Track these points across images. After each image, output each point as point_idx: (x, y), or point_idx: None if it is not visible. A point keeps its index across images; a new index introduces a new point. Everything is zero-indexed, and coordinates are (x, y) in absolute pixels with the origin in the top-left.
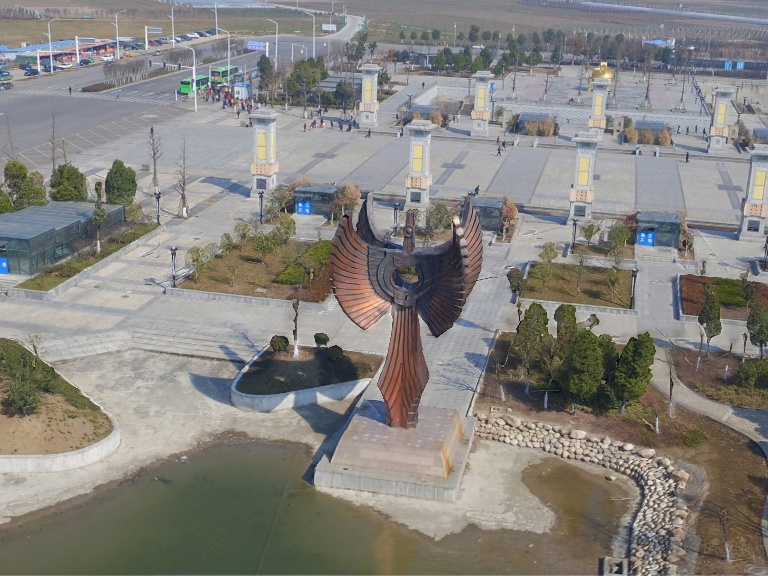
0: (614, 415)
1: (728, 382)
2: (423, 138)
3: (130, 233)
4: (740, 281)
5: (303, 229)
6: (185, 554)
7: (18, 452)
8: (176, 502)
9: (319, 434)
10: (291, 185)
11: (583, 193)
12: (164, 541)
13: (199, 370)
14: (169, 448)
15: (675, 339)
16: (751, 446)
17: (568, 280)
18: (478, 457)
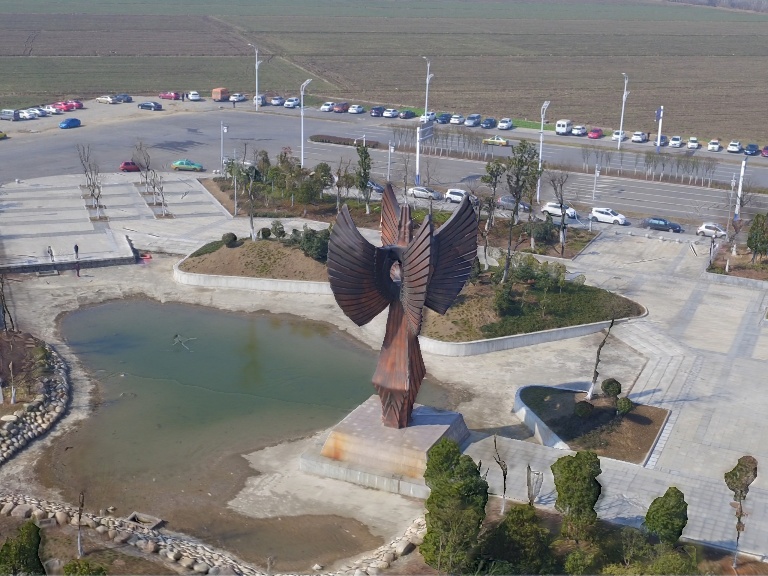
0: None
1: None
2: None
3: None
4: None
5: None
6: (278, 375)
7: None
8: (354, 375)
9: None
10: None
11: None
12: (299, 370)
13: None
14: (441, 373)
15: None
16: None
17: None
18: (391, 498)
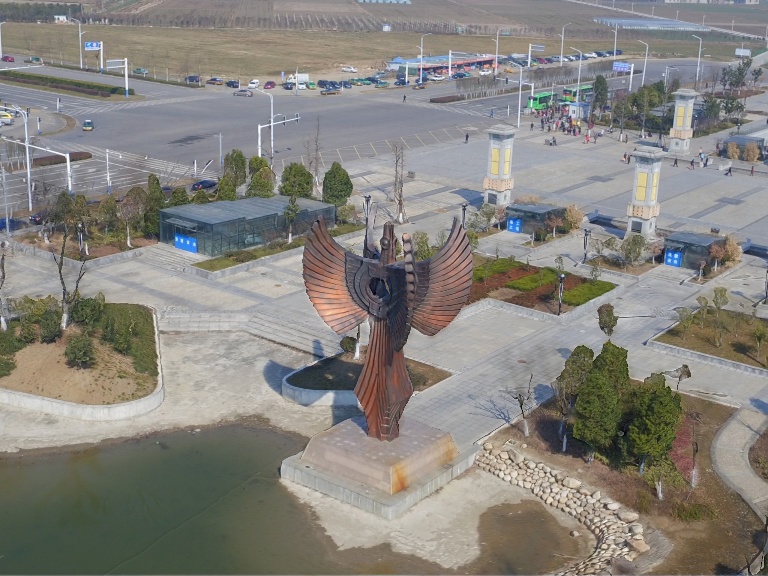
0: (628, 472)
1: None
2: (648, 165)
3: (330, 230)
4: None
5: (501, 246)
6: (120, 509)
7: (61, 398)
8: (156, 465)
9: None
10: (514, 202)
11: None
12: (115, 495)
13: (281, 358)
14: (193, 420)
15: None
16: (758, 535)
17: (728, 330)
18: (458, 484)
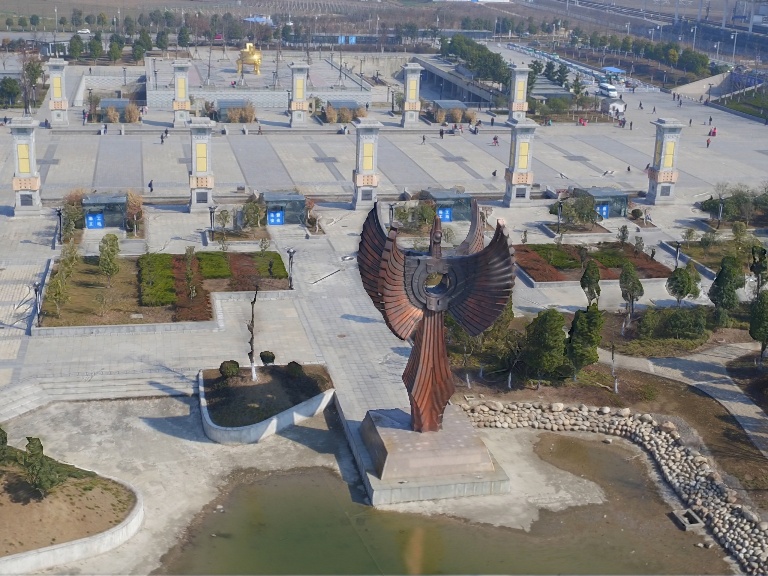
0: (571, 384)
1: (629, 337)
2: (206, 136)
3: None
4: (550, 245)
5: None
6: None
7: (57, 541)
8: (255, 554)
9: (326, 454)
10: (67, 198)
11: (369, 177)
12: None
13: (146, 412)
14: (195, 500)
15: (548, 306)
16: (693, 390)
17: None
18: (487, 446)
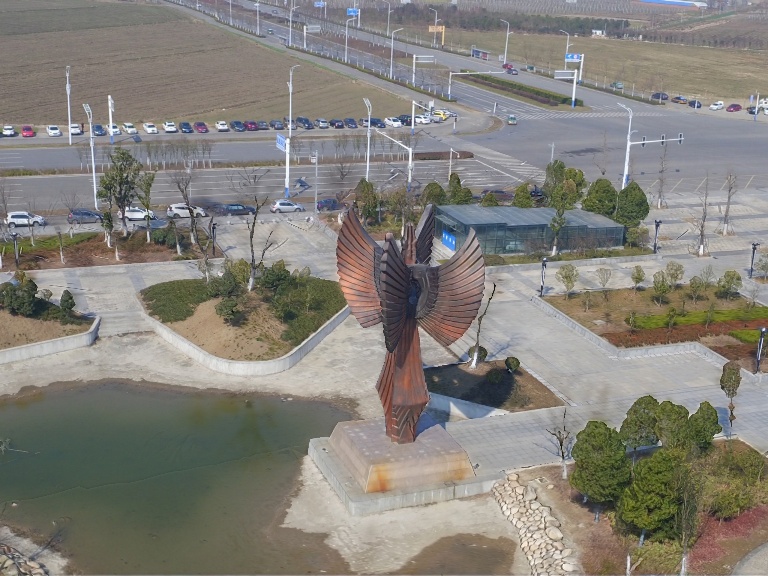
0: (624, 540)
1: None
2: None
3: (605, 250)
4: None
5: None
6: (160, 444)
7: (203, 346)
8: (227, 418)
9: None
10: None
11: None
12: (170, 432)
13: (428, 356)
14: (295, 390)
15: None
16: None
17: None
18: (455, 505)
